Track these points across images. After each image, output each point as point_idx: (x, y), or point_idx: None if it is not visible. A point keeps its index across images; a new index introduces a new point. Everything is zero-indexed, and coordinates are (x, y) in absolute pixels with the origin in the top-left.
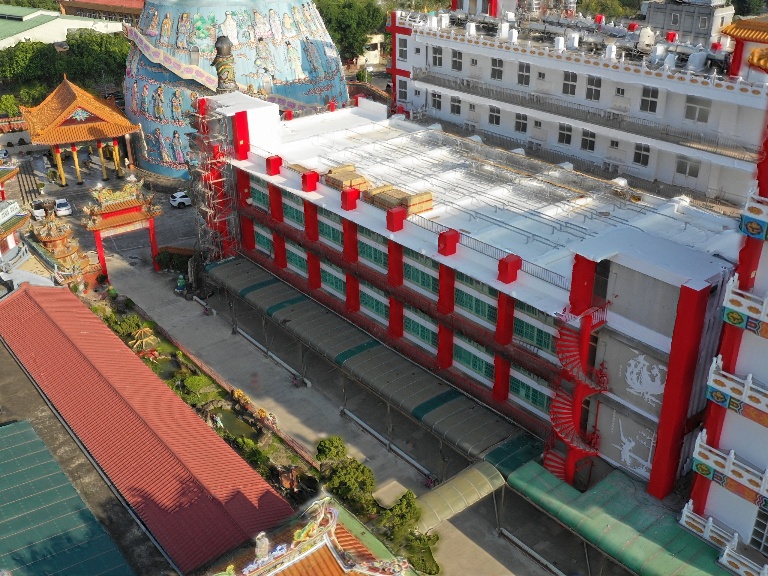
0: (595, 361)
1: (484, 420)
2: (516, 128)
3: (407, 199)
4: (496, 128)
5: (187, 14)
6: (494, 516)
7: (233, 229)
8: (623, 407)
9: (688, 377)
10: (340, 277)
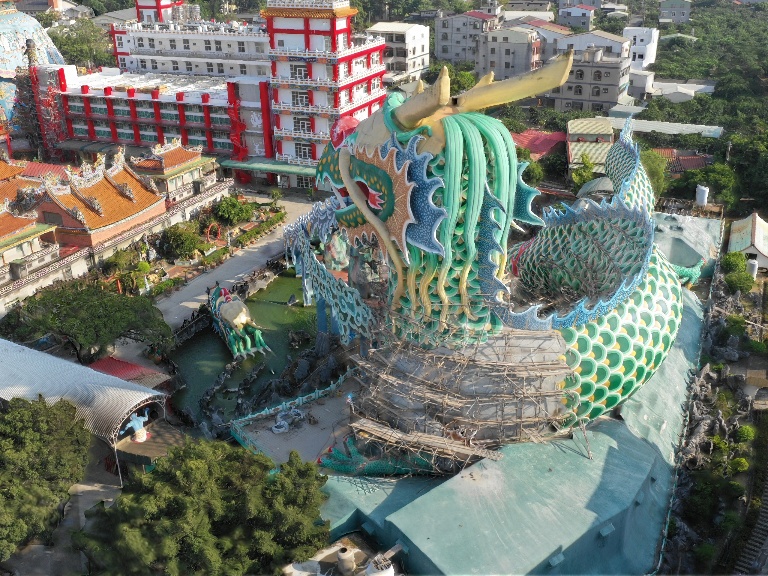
0: (241, 121)
1: (207, 156)
2: (187, 70)
3: (158, 86)
4: None
5: None
6: None
7: (63, 127)
8: (253, 133)
9: (268, 112)
10: (129, 132)
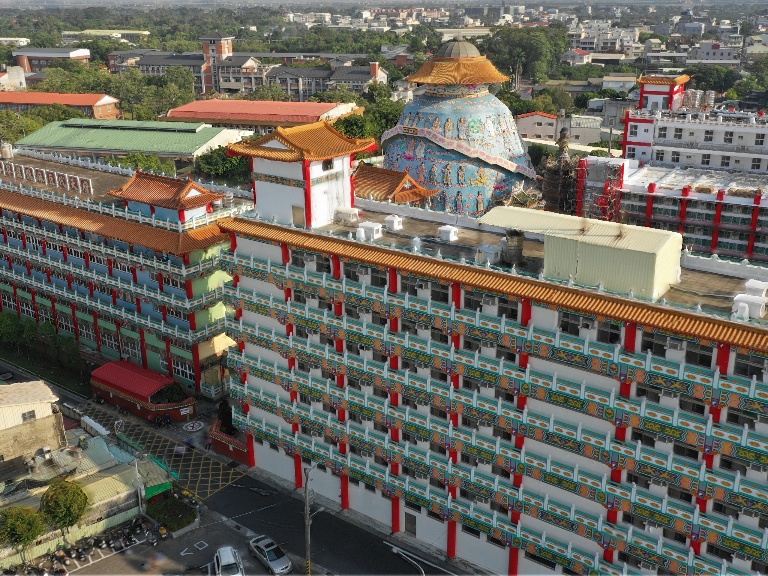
0: None
1: None
2: (722, 165)
3: None
4: (707, 166)
5: (464, 118)
6: None
7: None
8: None
9: None
10: (701, 238)
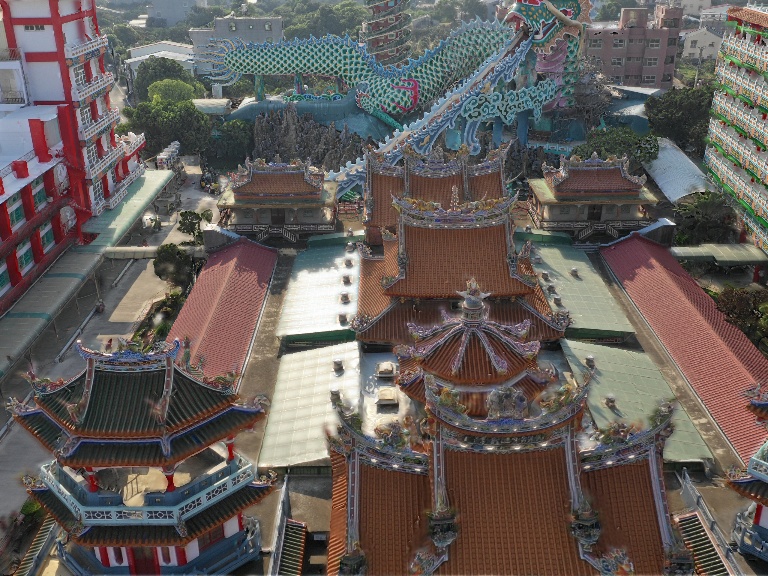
0: None
1: (68, 261)
2: None
3: None
4: None
5: None
6: (105, 291)
7: None
8: None
9: None
10: None
